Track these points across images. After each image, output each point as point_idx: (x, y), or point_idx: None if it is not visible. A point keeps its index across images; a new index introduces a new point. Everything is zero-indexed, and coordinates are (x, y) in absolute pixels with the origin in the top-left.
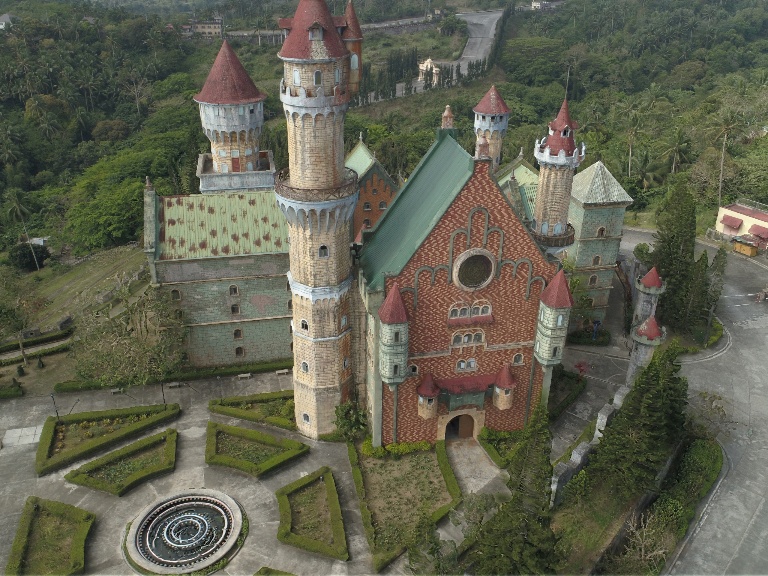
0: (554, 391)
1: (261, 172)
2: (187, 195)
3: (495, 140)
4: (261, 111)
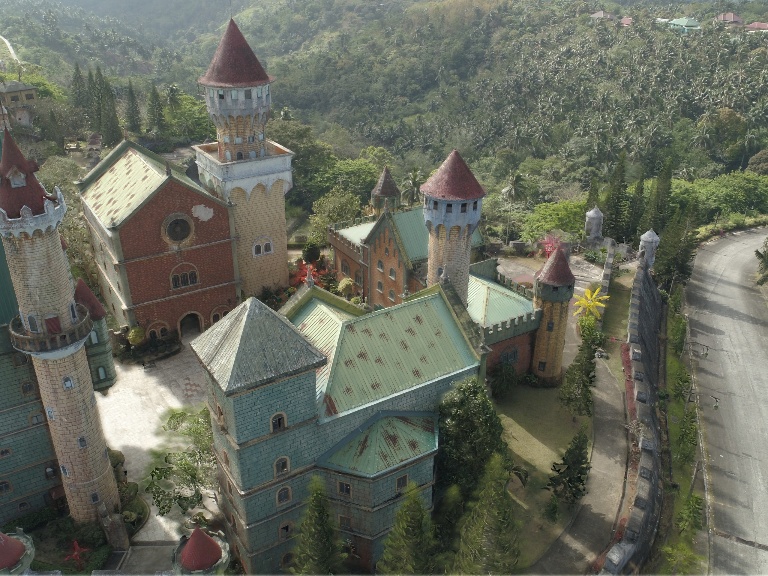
0: (60, 546)
1: (215, 161)
2: (137, 153)
3: (435, 237)
4: (240, 100)
